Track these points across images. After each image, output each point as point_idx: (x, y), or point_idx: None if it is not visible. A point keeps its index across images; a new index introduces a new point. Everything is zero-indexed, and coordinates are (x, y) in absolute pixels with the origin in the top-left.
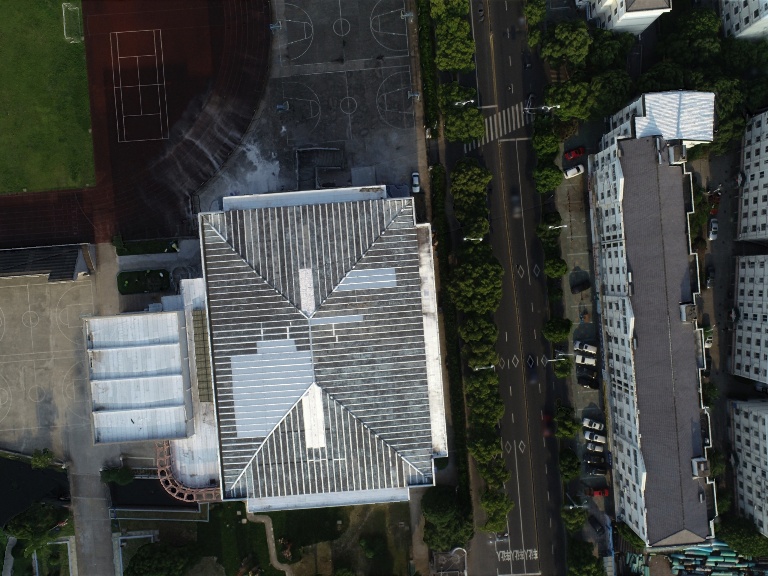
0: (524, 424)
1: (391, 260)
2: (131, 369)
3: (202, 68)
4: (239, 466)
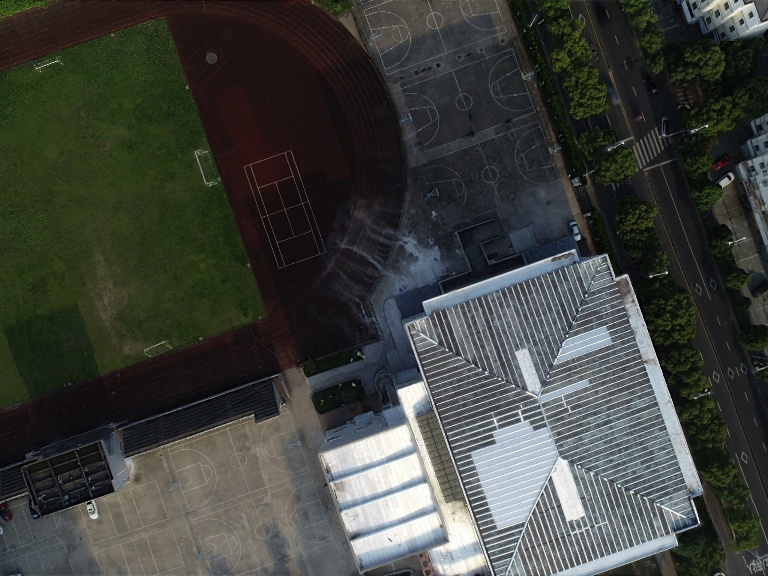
0: (741, 435)
1: (600, 319)
2: (376, 490)
3: (340, 177)
4: (506, 556)
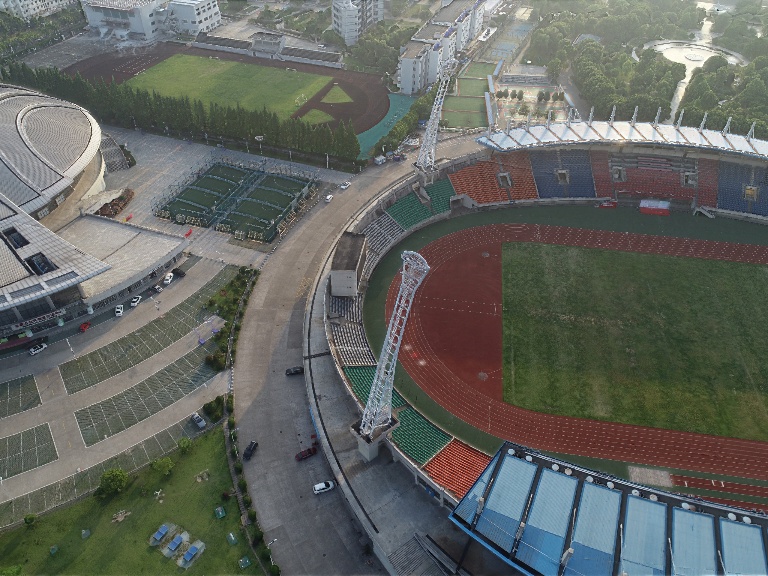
0: None
1: None
2: None
3: (112, 62)
4: None
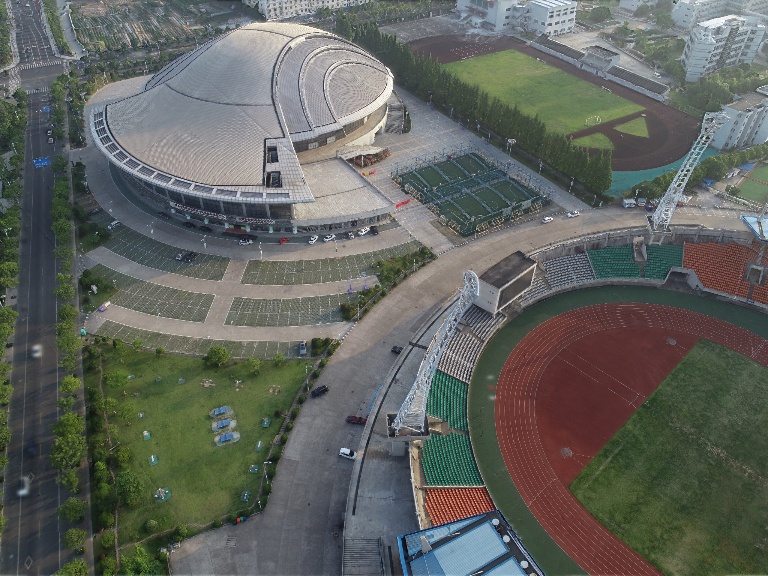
0: None
1: None
2: None
3: None
4: None
